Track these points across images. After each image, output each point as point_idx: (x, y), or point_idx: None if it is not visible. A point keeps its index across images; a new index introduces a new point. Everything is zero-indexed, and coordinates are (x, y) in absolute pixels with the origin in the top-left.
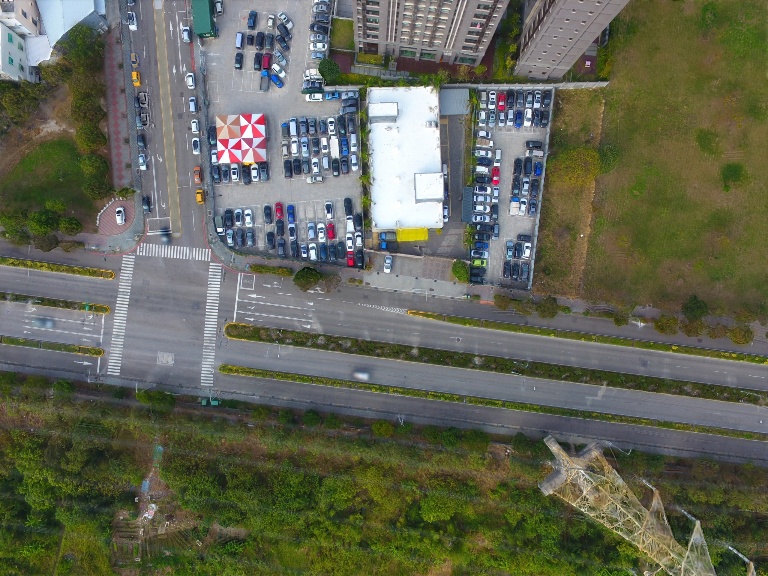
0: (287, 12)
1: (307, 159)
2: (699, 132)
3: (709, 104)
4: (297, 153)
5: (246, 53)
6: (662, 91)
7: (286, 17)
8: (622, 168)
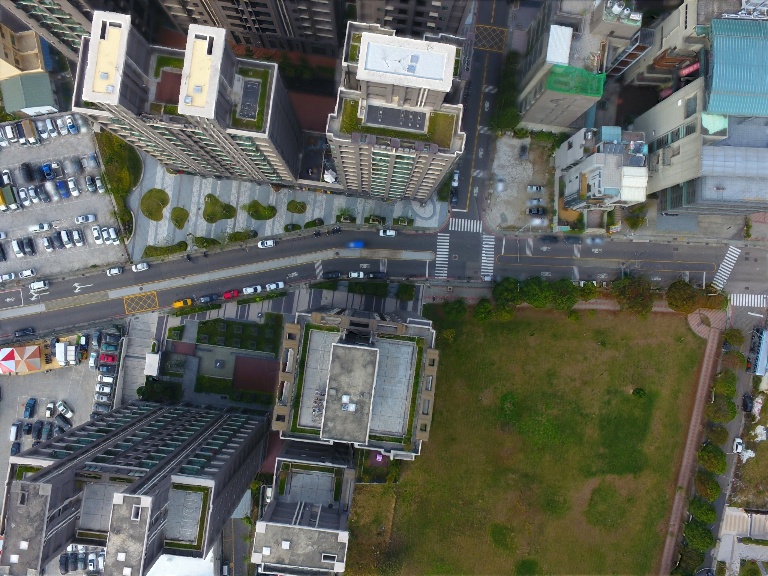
0: (68, 399)
1: (83, 556)
2: (494, 527)
3: (505, 497)
4: (72, 550)
5: (24, 441)
6: (457, 484)
7: (64, 408)
8: (413, 564)
